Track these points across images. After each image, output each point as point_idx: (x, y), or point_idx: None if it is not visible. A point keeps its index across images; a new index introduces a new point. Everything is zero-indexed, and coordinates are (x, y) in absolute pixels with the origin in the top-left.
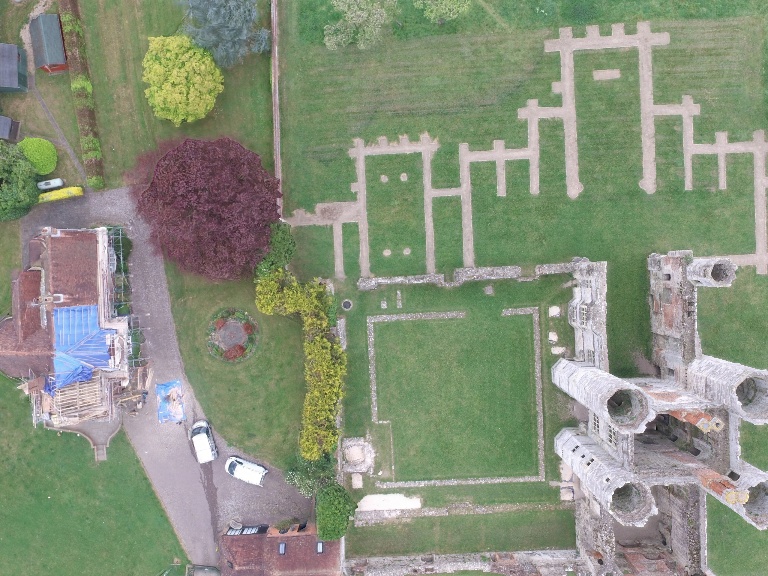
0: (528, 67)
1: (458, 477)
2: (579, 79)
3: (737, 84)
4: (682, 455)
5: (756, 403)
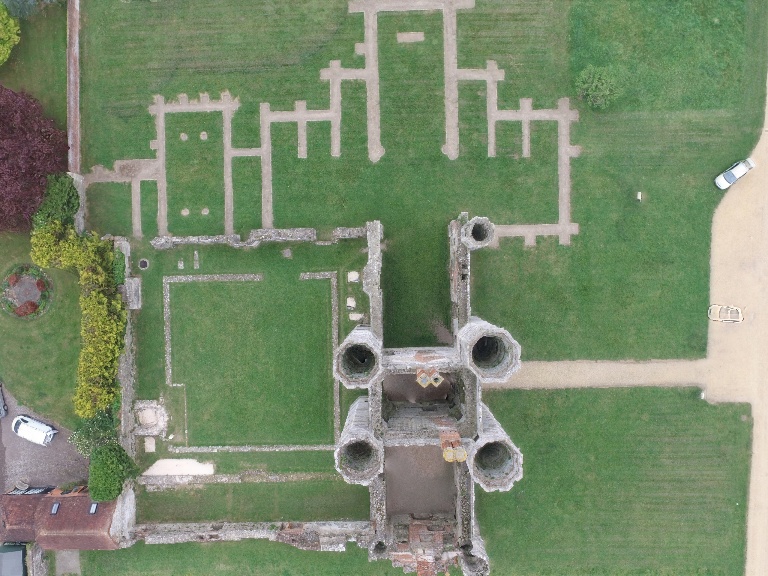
0: (331, 27)
1: (252, 443)
2: (382, 41)
3: (542, 50)
4: (446, 420)
5: (501, 364)
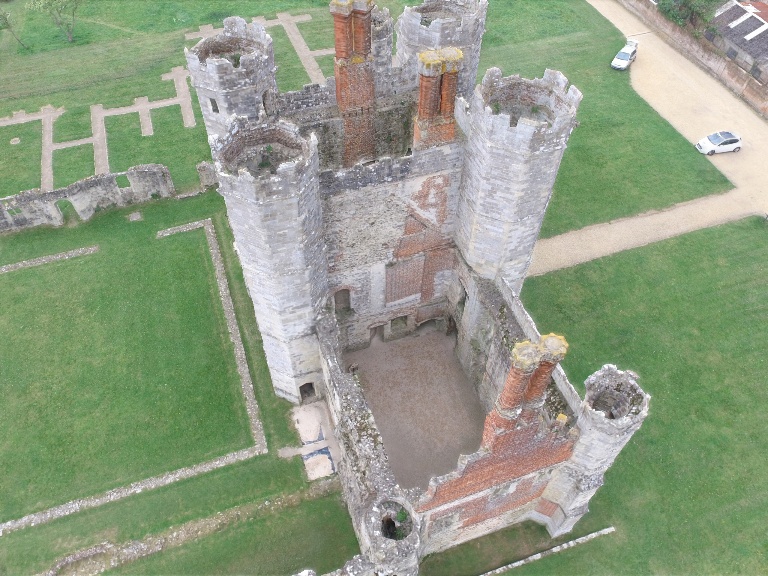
0: (169, 50)
1: (83, 495)
2: None
3: None
4: None
5: None
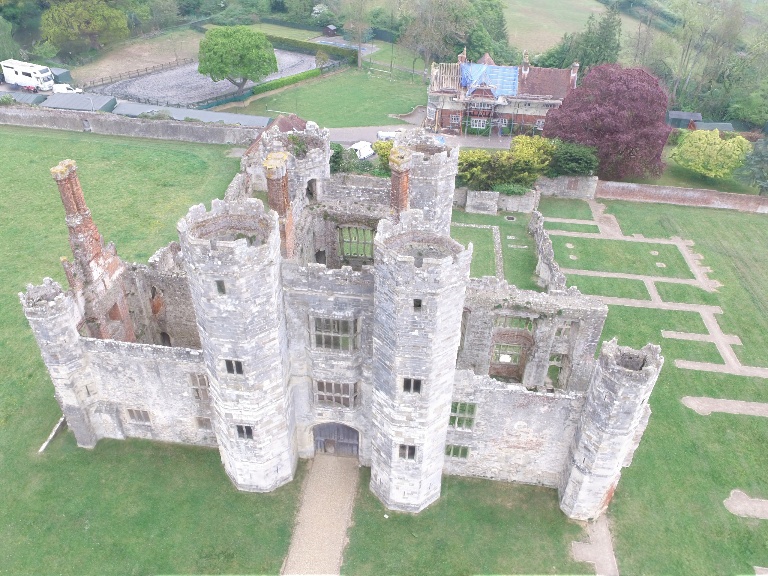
0: None
1: None
2: None
3: None
4: None
5: None
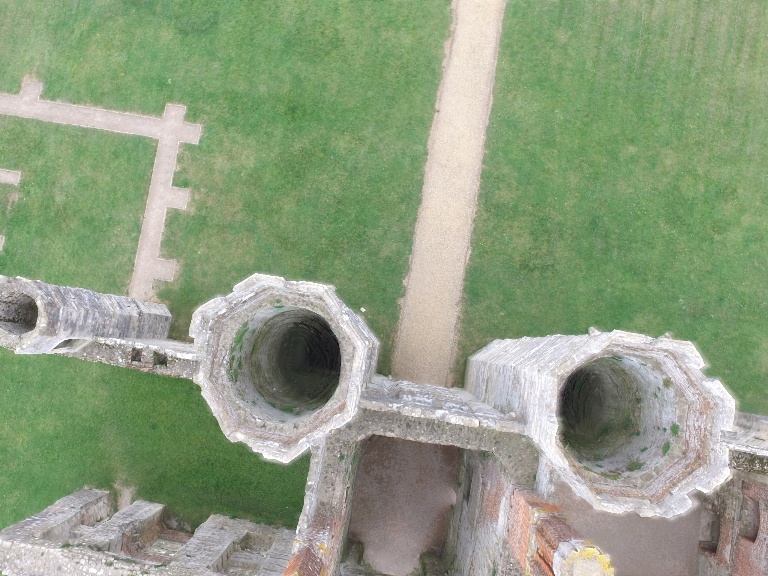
0: None
1: None
2: None
3: None
4: (489, 481)
5: None
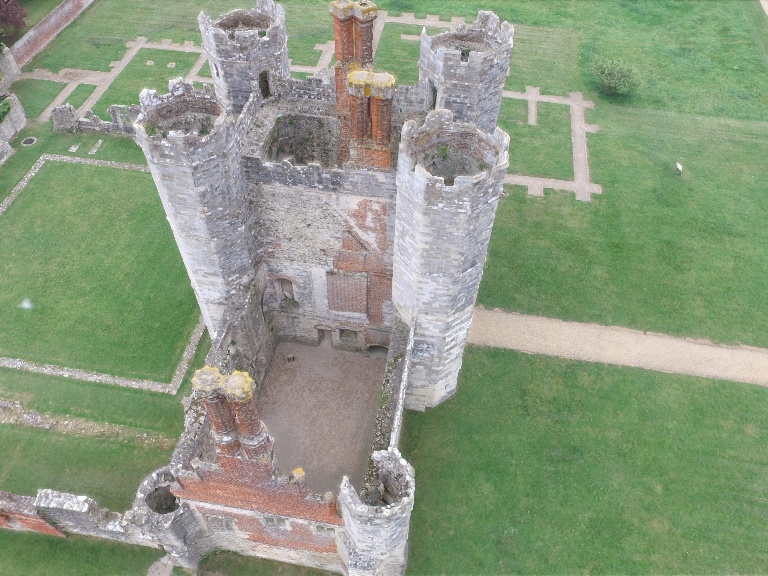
0: None
1: (30, 359)
2: (386, 36)
3: (551, 61)
4: None
5: None
